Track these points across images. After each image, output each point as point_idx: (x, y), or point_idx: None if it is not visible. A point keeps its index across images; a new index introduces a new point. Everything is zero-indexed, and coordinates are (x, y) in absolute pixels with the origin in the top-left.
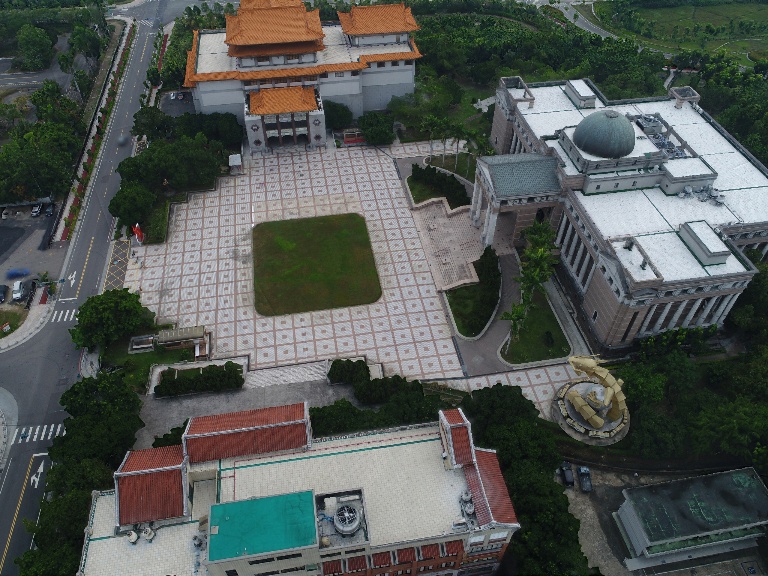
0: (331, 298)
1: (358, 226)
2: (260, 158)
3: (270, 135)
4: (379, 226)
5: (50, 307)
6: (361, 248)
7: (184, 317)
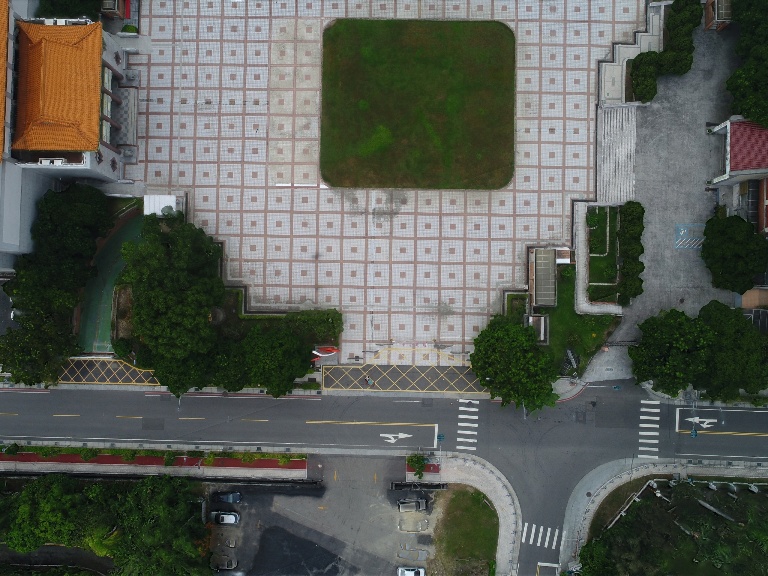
0: (497, 89)
1: (357, 31)
2: (144, 168)
3: (107, 137)
4: (362, 0)
5: (447, 457)
6: (406, 34)
7: (494, 281)
